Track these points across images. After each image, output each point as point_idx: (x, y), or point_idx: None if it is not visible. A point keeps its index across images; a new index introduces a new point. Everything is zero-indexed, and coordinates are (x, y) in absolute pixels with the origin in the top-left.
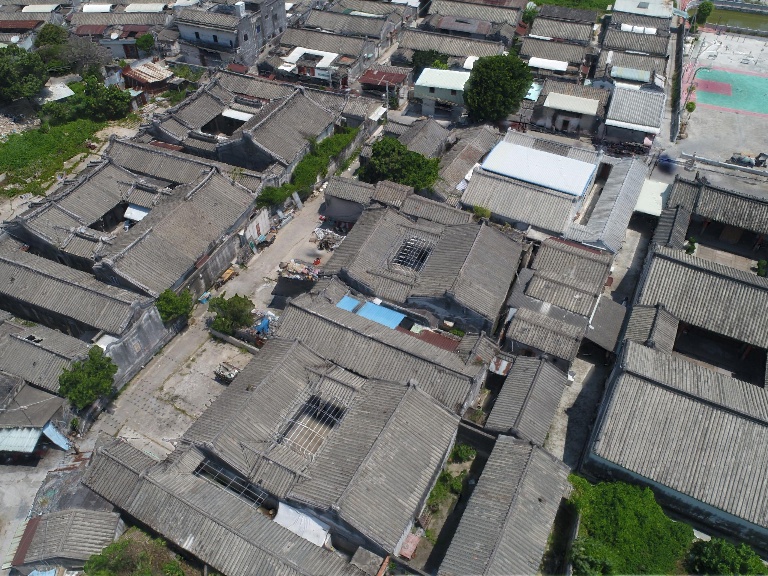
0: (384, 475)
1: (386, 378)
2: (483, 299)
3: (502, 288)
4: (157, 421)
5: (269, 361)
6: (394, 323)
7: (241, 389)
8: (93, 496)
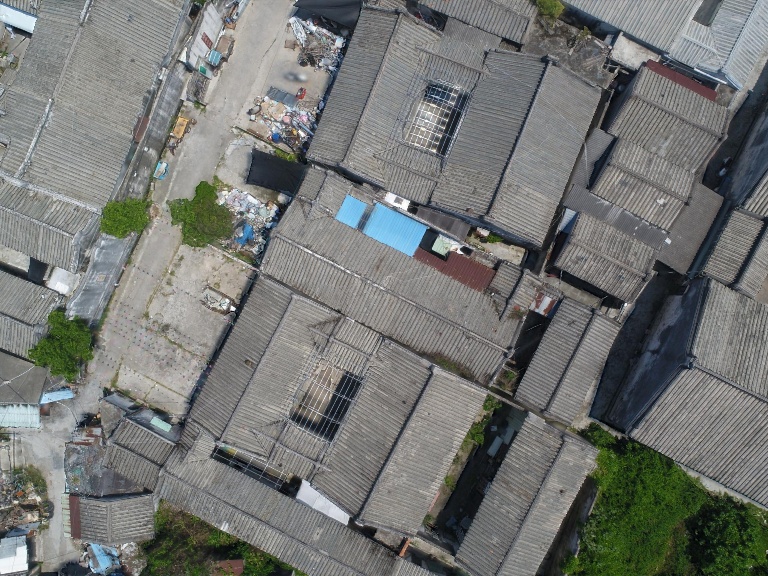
0: (405, 474)
1: (404, 337)
2: (532, 209)
3: (561, 182)
4: (155, 359)
5: (264, 321)
6: (413, 244)
7: (239, 360)
8: (120, 476)
